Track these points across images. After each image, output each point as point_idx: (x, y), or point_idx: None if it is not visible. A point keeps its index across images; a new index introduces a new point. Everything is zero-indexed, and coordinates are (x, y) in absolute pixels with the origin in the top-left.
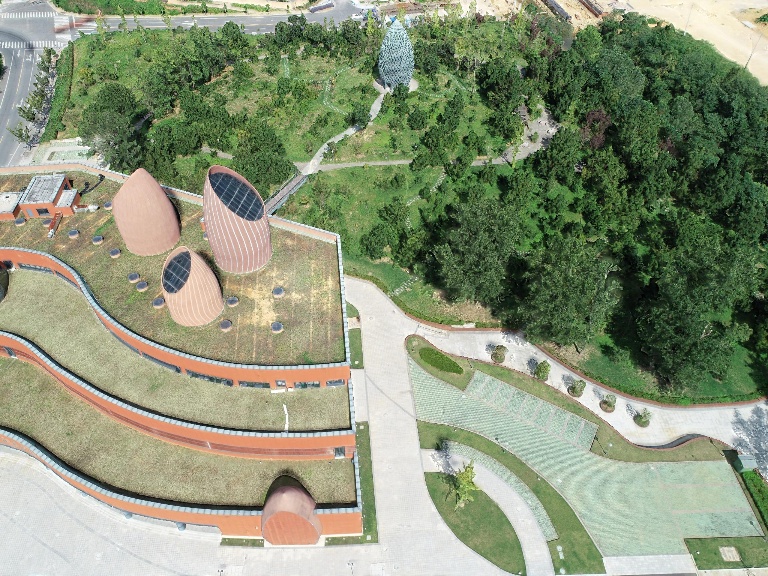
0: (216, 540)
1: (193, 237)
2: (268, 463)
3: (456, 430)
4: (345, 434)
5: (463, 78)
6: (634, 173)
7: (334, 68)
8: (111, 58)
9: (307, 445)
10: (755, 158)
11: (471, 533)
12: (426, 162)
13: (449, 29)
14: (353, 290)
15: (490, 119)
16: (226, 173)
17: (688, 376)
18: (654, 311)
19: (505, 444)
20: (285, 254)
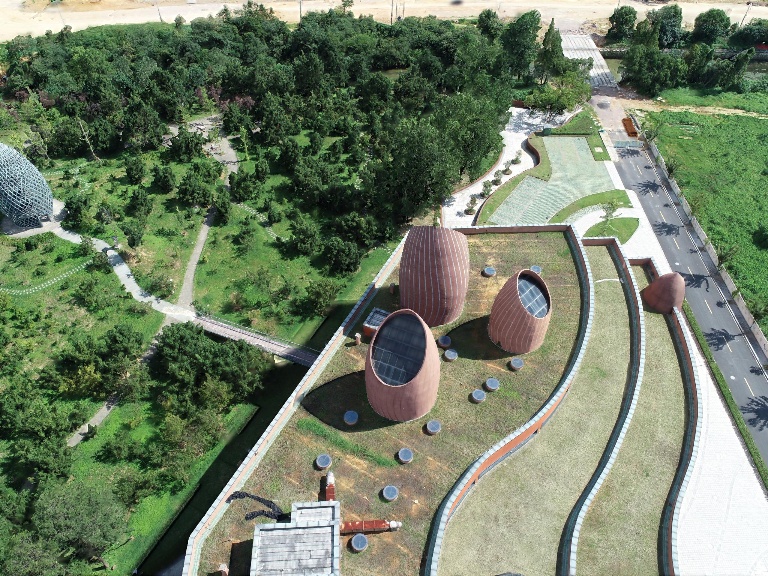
0: None
1: None
2: None
3: None
4: None
5: (54, 166)
6: None
7: None
8: None
9: None
10: None
11: (620, 236)
12: None
13: None
14: None
15: (161, 158)
16: None
17: None
18: None
19: None
20: None
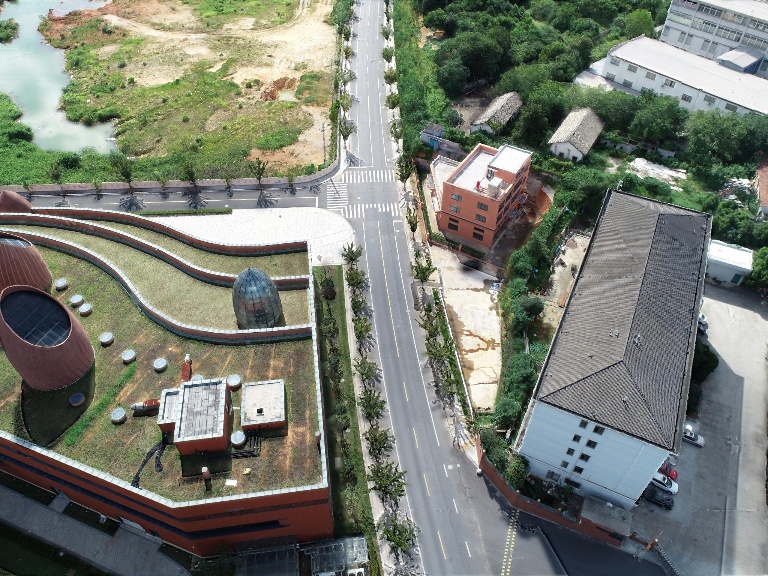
0: None
1: (10, 366)
2: None
3: None
4: None
5: None
6: None
7: None
8: None
9: None
10: None
11: None
12: None
13: None
14: None
15: None
16: None
17: None
18: None
19: None
20: None
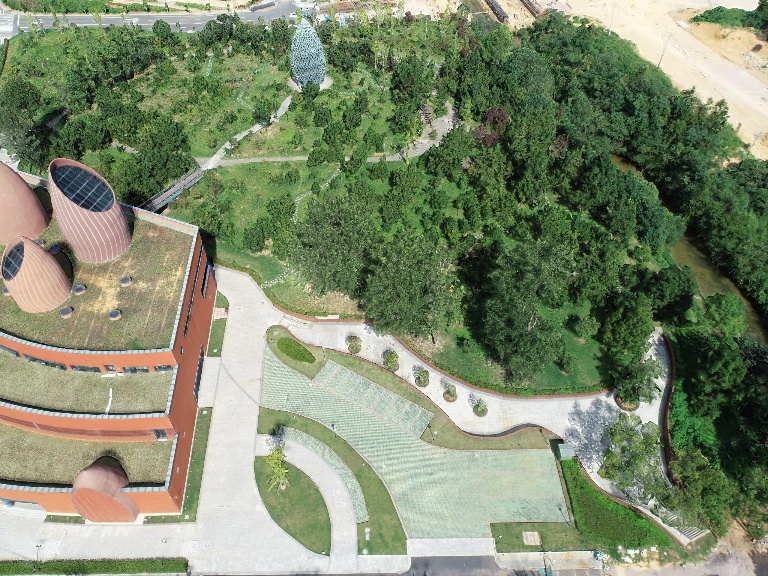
0: (41, 517)
1: None
2: (93, 444)
3: (295, 416)
4: (157, 416)
5: (379, 76)
6: (518, 170)
7: (256, 66)
8: (40, 55)
9: (125, 427)
10: (654, 157)
11: (286, 514)
12: (320, 158)
13: (378, 28)
14: (228, 282)
15: (395, 117)
16: (75, 166)
17: (519, 367)
18: (487, 303)
19: (339, 430)
20: (144, 245)
